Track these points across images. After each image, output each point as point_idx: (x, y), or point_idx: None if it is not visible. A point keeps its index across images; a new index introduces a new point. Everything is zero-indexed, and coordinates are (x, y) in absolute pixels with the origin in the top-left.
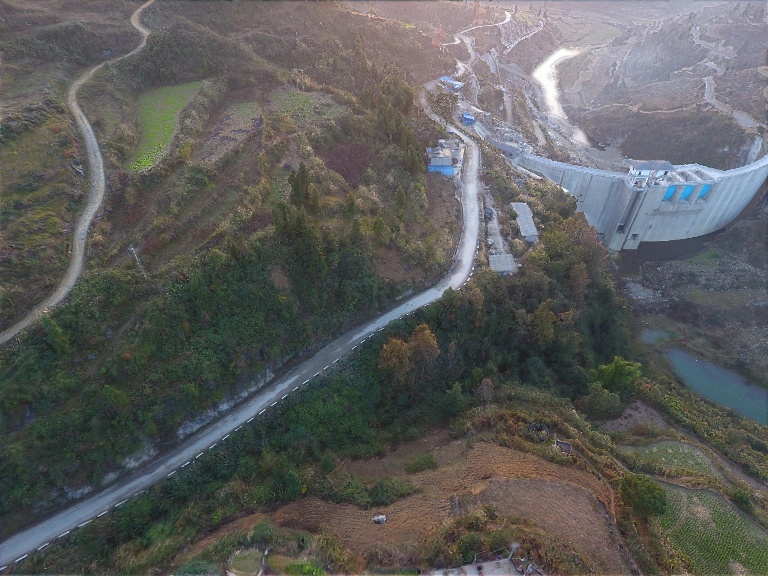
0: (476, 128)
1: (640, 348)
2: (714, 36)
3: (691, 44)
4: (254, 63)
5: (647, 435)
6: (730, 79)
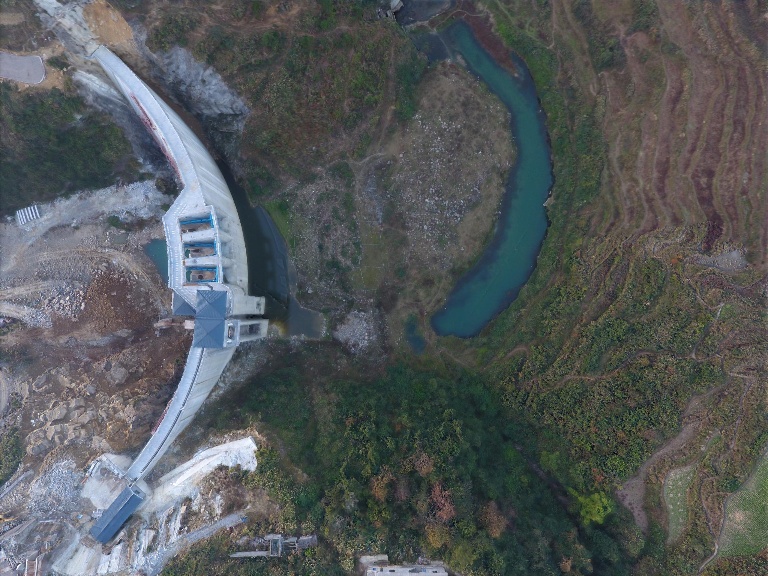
0: (77, 573)
1: (438, 364)
2: None
3: None
4: None
5: (660, 508)
6: None
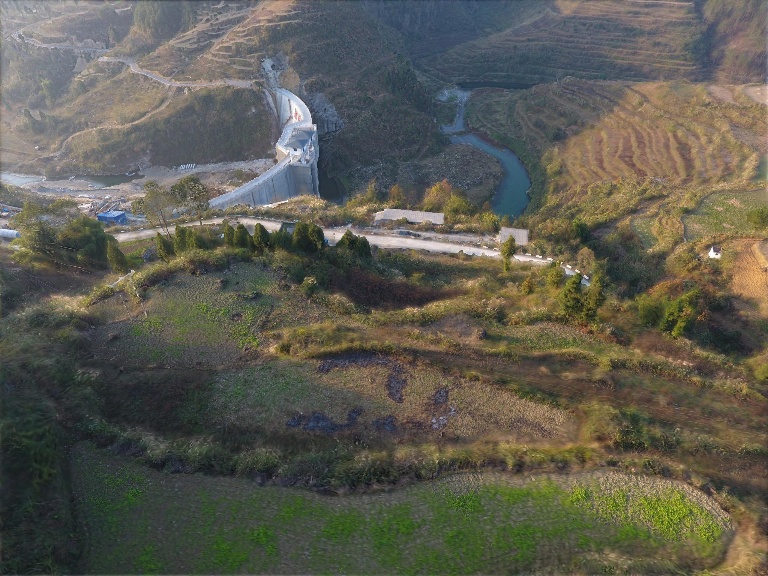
0: (136, 219)
1: None
2: (57, 36)
3: (45, 50)
4: (14, 358)
5: None
6: (161, 62)
